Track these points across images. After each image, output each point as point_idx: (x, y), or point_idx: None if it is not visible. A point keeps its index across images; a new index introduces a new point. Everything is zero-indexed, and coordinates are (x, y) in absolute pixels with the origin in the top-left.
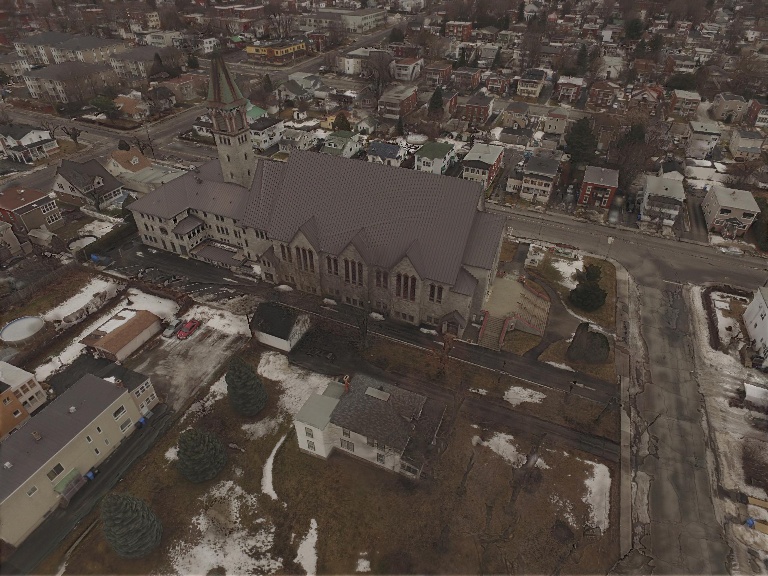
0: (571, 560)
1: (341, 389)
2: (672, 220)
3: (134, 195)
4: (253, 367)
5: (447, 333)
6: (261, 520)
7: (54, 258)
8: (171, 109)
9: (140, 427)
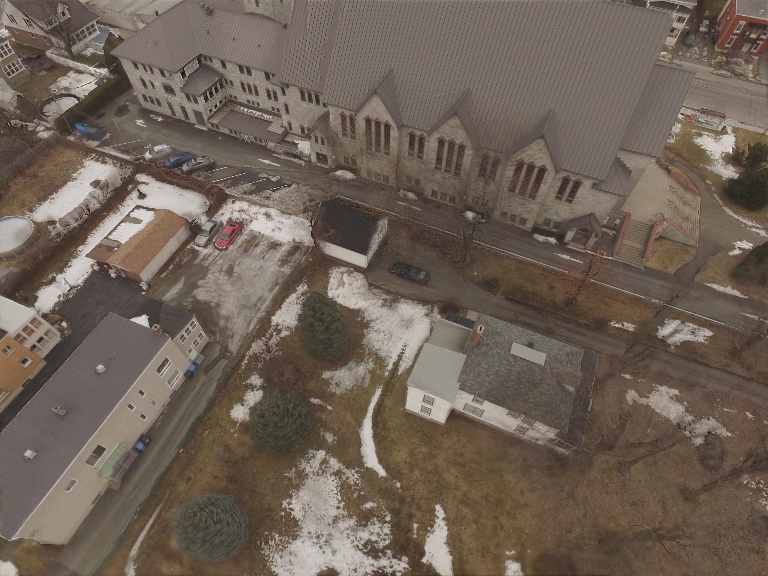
0: None
1: (456, 331)
2: None
3: (115, 33)
4: (335, 303)
5: (571, 242)
6: (370, 505)
7: (26, 130)
8: None
9: (191, 376)
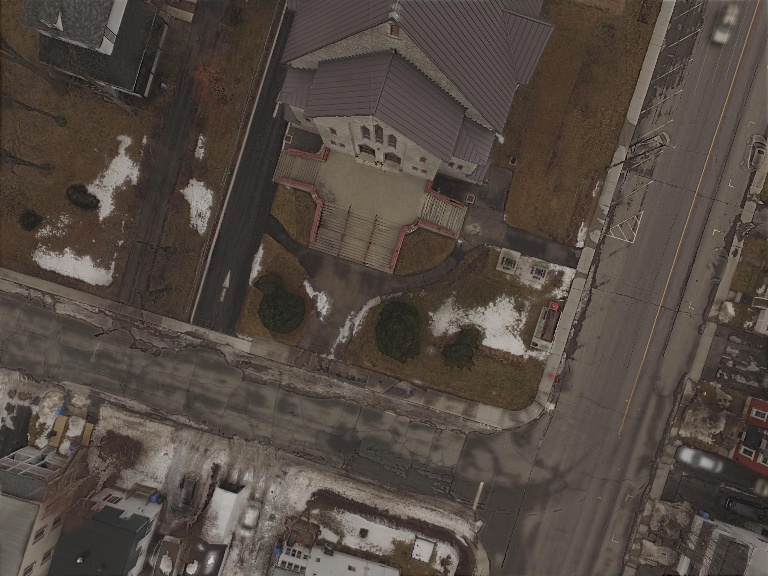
0: (6, 223)
1: None
2: (687, 575)
3: None
4: None
5: None
6: None
7: None
8: None
9: None
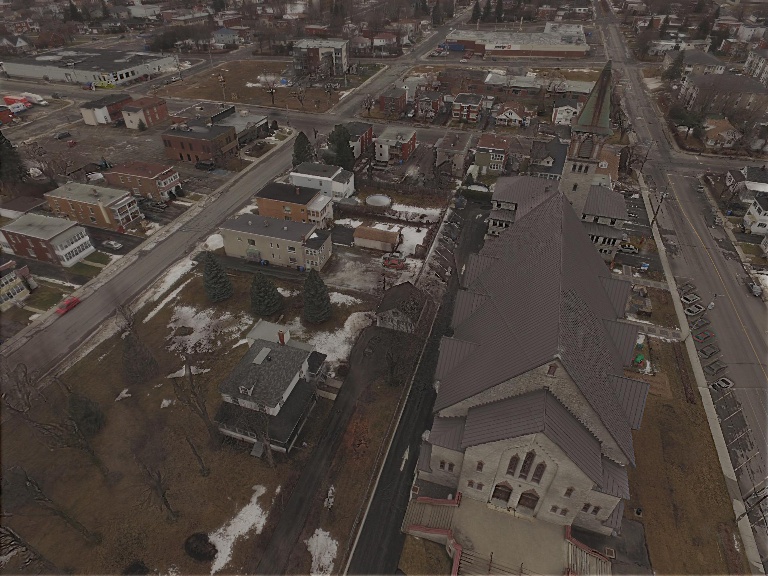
0: None
1: None
2: None
3: None
4: (321, 290)
5: None
6: (219, 343)
7: None
8: (760, 152)
9: (298, 270)
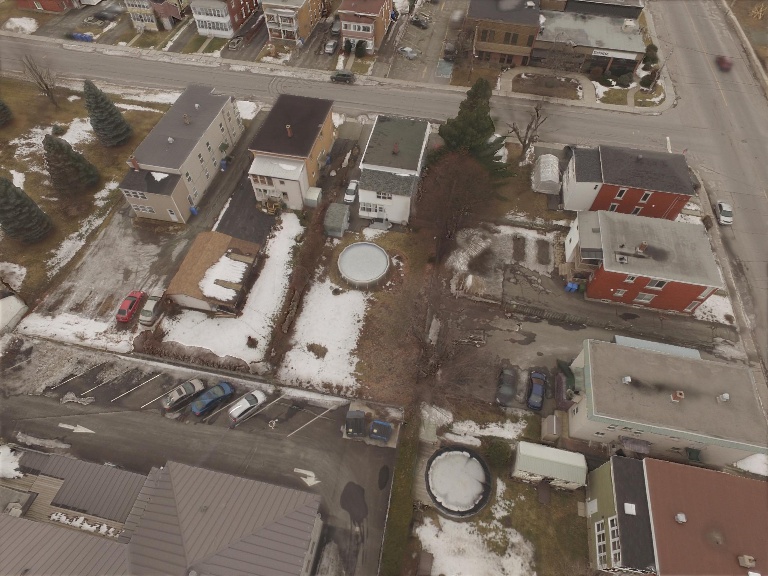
0: None
1: None
2: None
3: None
4: None
5: None
6: (25, 159)
7: None
8: None
9: None
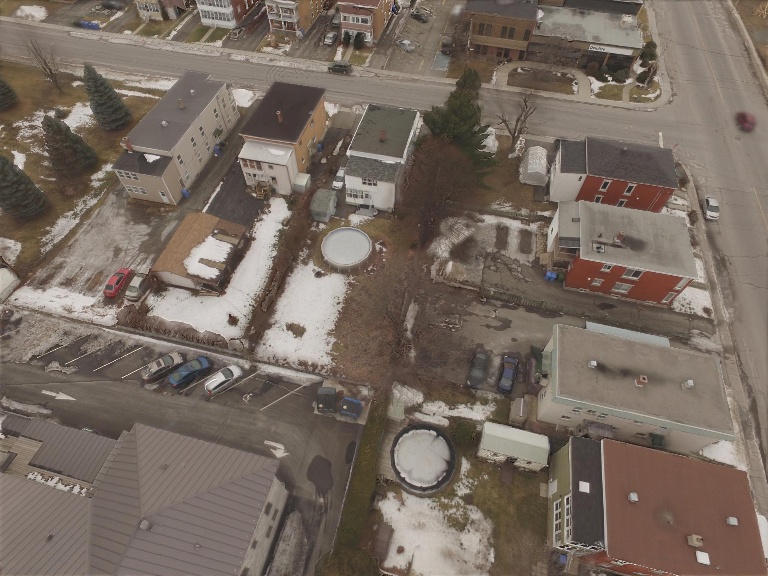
0: None
1: None
2: None
3: None
4: None
5: None
6: (27, 141)
7: None
8: None
9: None
